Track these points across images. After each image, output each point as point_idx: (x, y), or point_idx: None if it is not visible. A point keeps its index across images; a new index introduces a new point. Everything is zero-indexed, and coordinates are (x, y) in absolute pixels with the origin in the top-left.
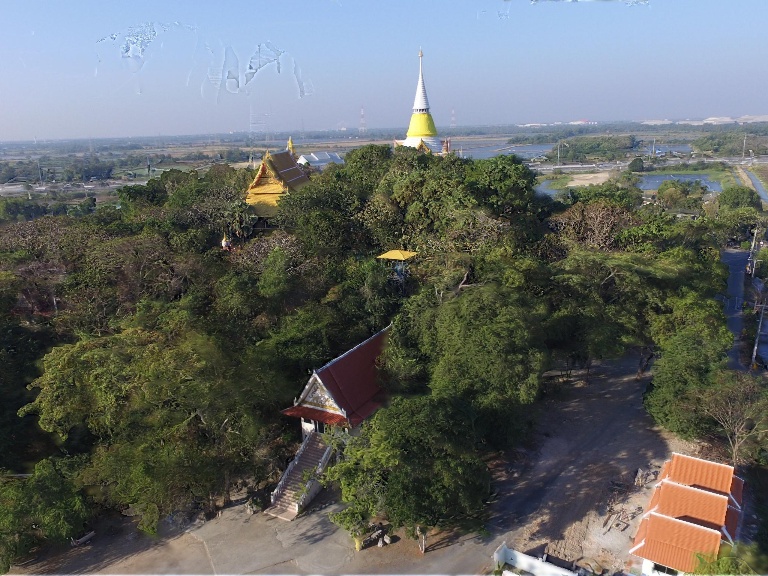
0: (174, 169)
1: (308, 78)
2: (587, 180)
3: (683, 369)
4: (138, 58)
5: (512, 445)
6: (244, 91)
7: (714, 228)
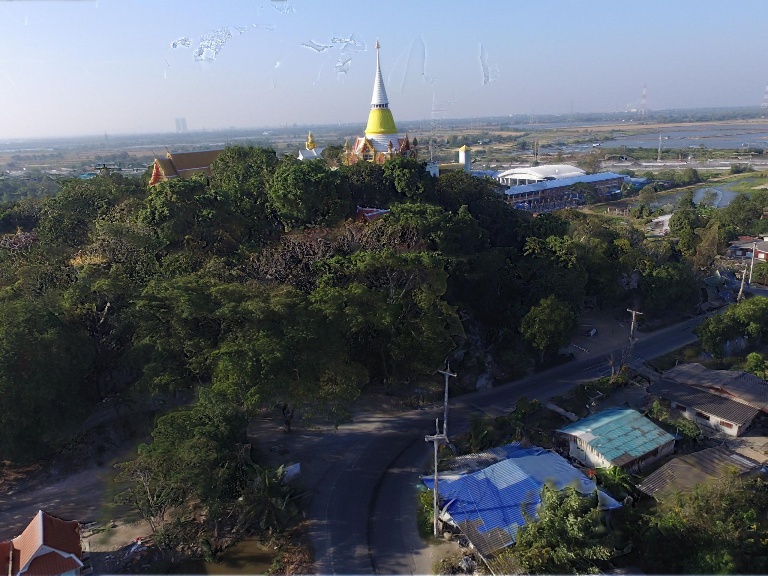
0: None
1: (494, 63)
2: None
3: (169, 426)
4: (211, 60)
5: (52, 464)
6: (429, 79)
7: (415, 265)
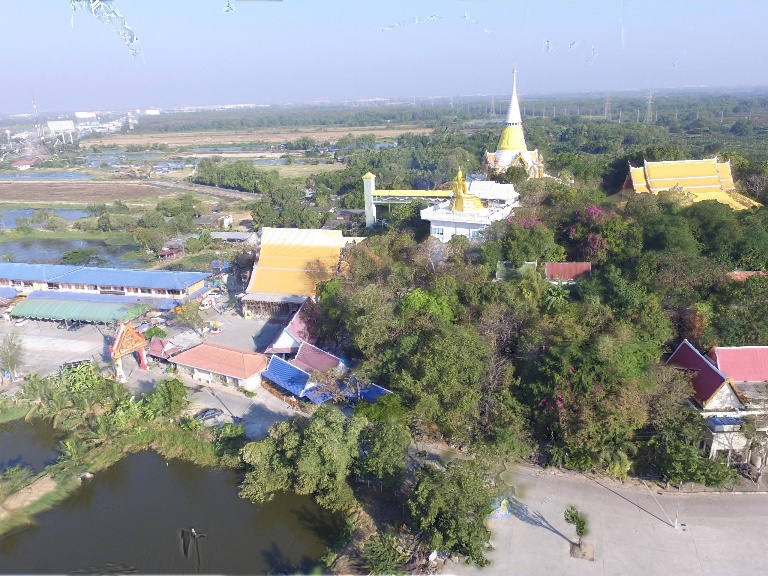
0: (709, 200)
1: None
2: None
3: None
4: None
5: None
6: None
7: None
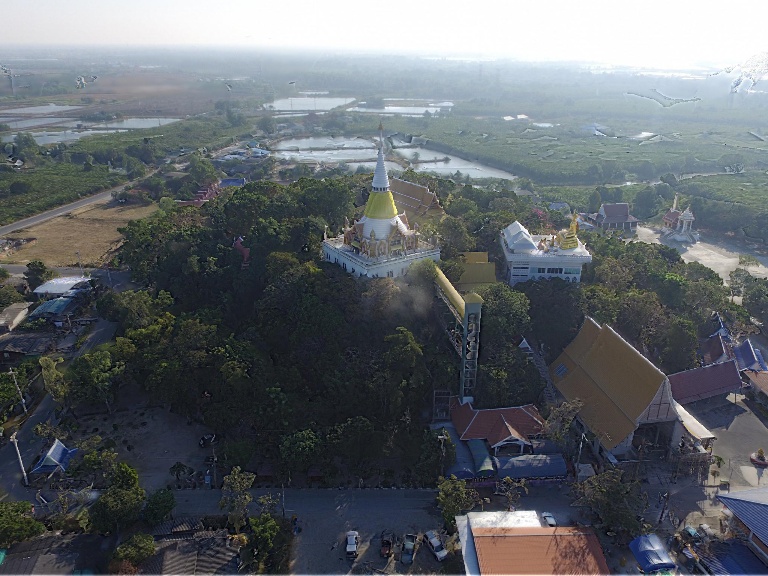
0: None
1: None
2: None
3: None
4: None
5: None
6: None
7: None
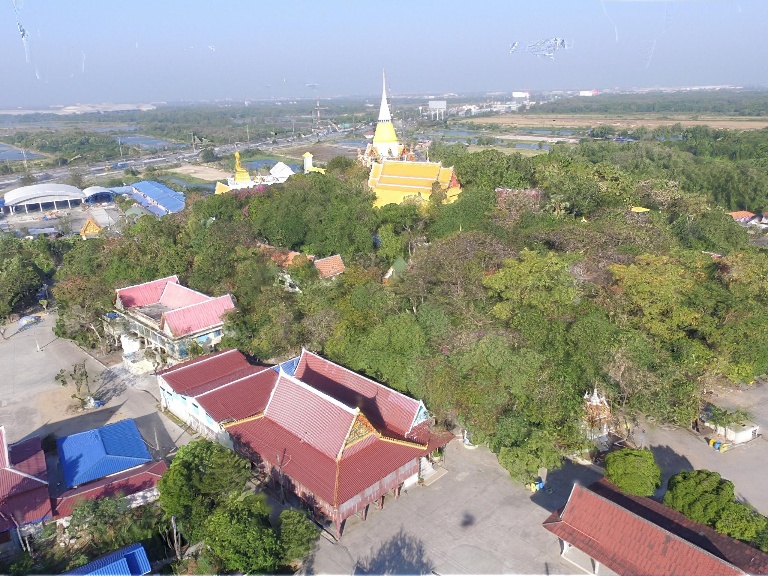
0: None
1: None
2: (200, 173)
3: None
4: None
5: None
6: None
7: None
